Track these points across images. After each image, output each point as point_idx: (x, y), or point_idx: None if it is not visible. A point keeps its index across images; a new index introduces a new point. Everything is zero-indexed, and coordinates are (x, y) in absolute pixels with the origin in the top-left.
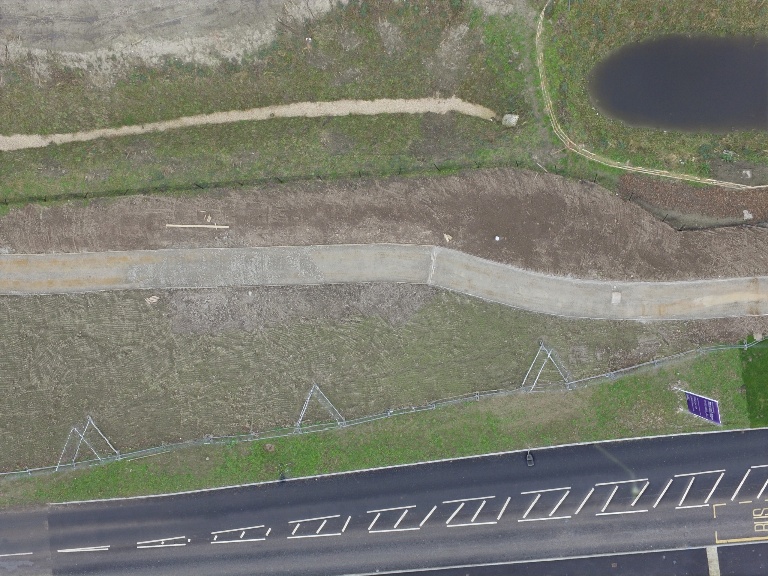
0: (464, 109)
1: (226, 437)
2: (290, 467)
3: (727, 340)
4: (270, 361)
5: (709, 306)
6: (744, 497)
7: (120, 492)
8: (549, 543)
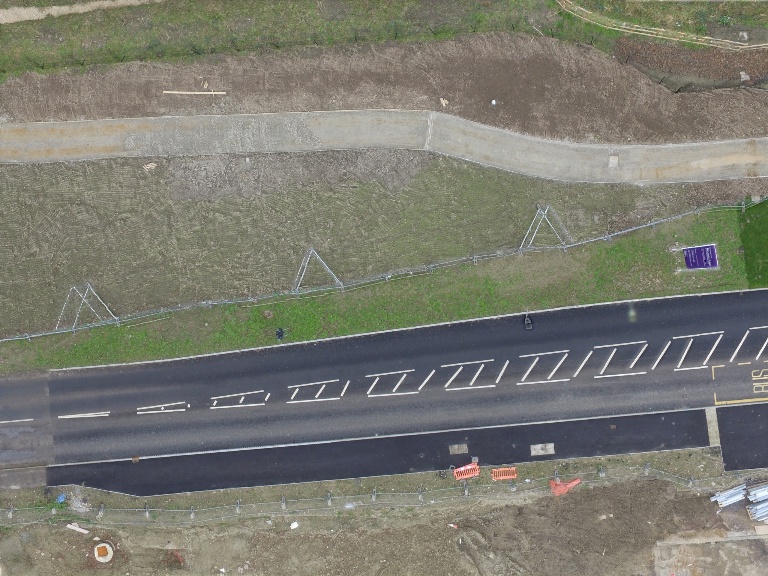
0: None
1: (225, 303)
2: (289, 332)
3: (725, 202)
4: (268, 227)
5: (707, 169)
6: (743, 358)
7: (120, 358)
8: (548, 406)
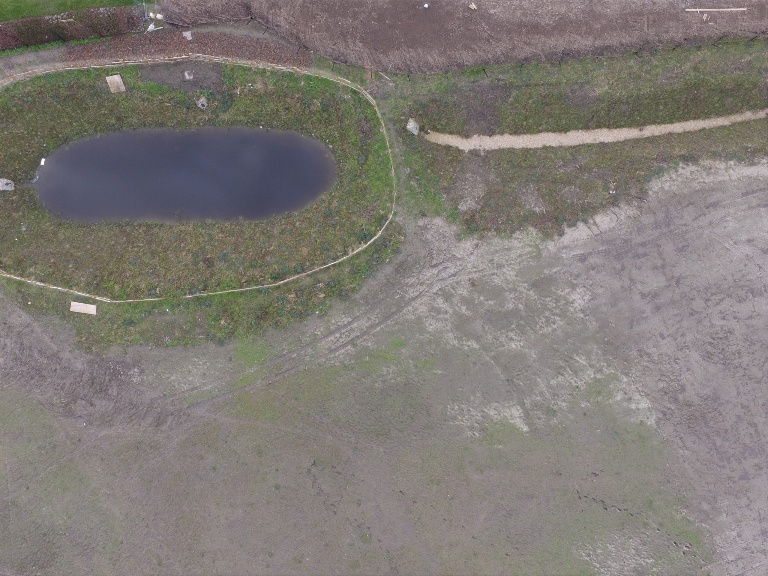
0: (456, 140)
1: None
2: None
3: None
4: None
5: None
6: None
7: None
8: None
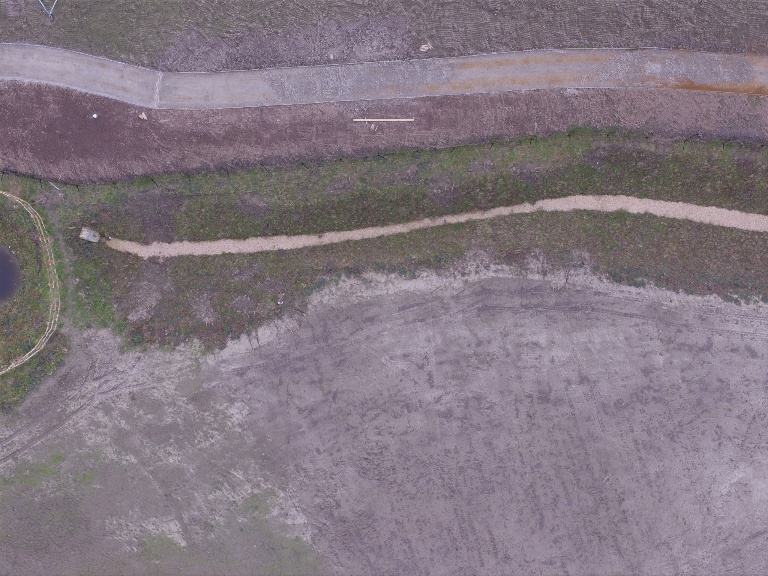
0: (136, 247)
1: None
2: None
3: None
4: None
5: None
6: None
7: None
8: None
